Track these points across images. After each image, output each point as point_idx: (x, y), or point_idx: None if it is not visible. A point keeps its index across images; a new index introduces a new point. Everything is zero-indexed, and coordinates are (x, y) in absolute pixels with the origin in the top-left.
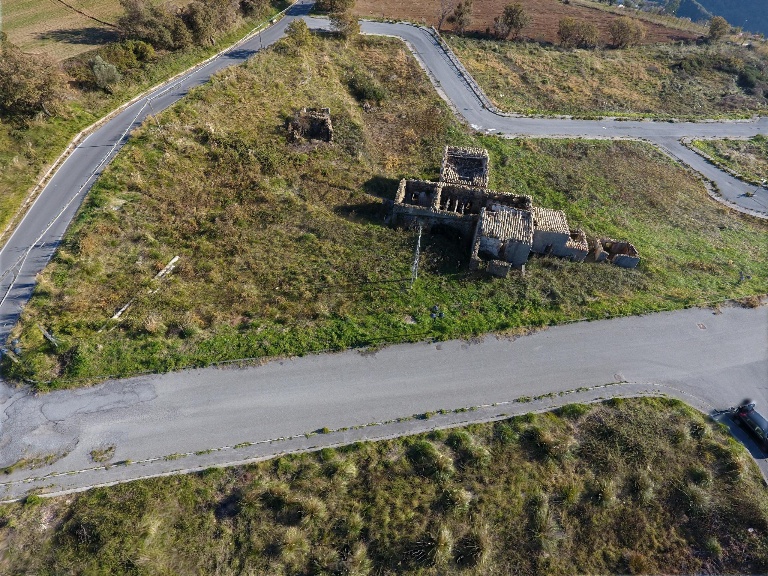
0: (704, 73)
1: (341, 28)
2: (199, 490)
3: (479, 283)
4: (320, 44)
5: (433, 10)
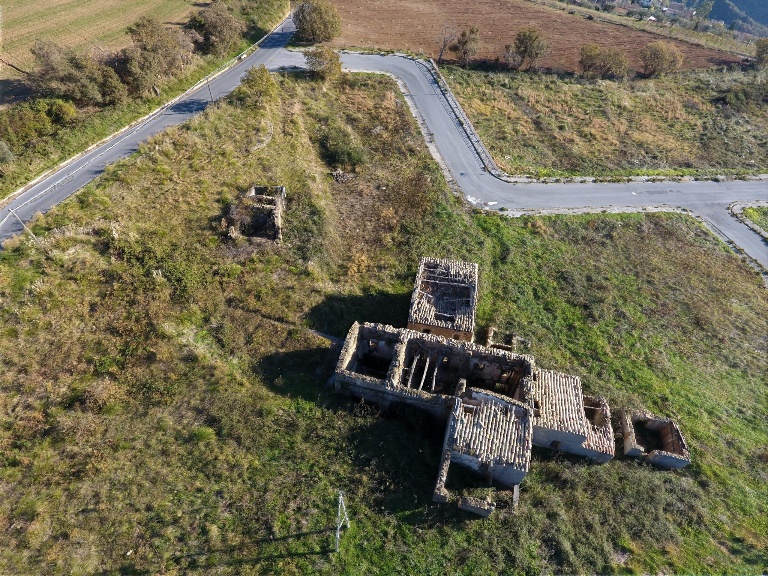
0: (752, 108)
1: (318, 68)
2: None
3: (445, 533)
4: (291, 88)
5: (436, 34)
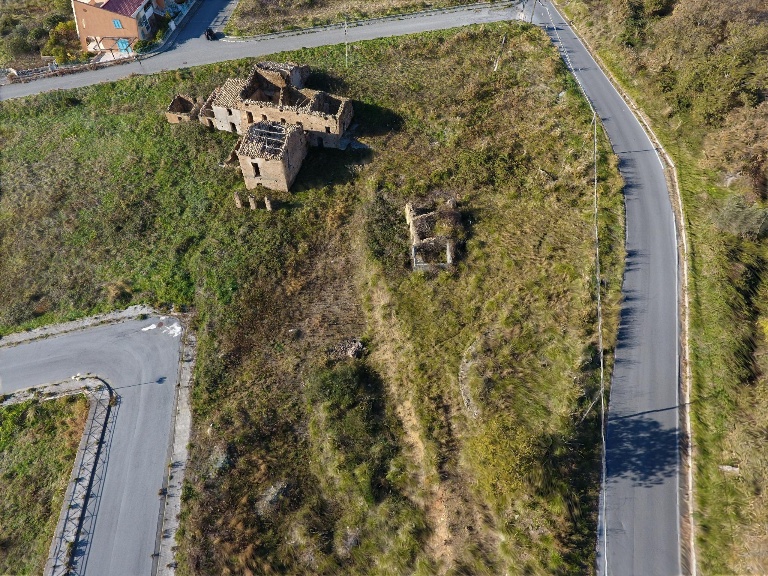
0: None
1: None
2: (440, 6)
3: None
4: None
5: None
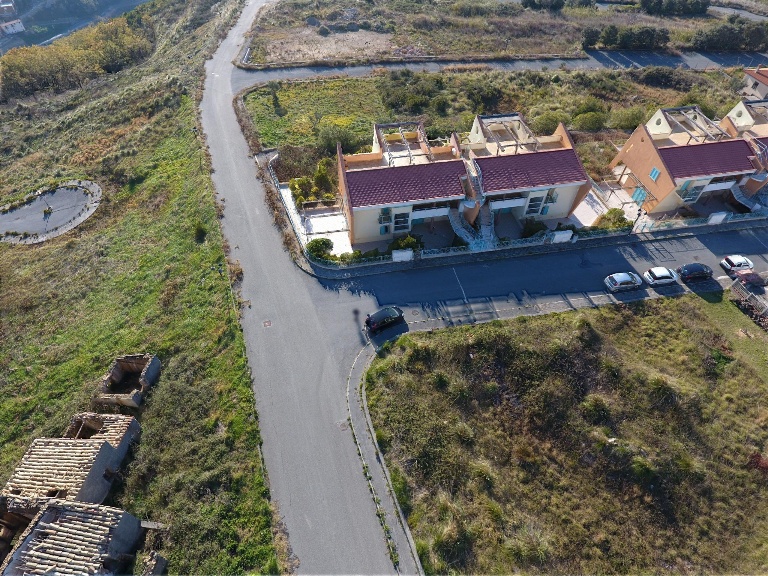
0: None
1: None
2: None
3: None
4: None
5: None
